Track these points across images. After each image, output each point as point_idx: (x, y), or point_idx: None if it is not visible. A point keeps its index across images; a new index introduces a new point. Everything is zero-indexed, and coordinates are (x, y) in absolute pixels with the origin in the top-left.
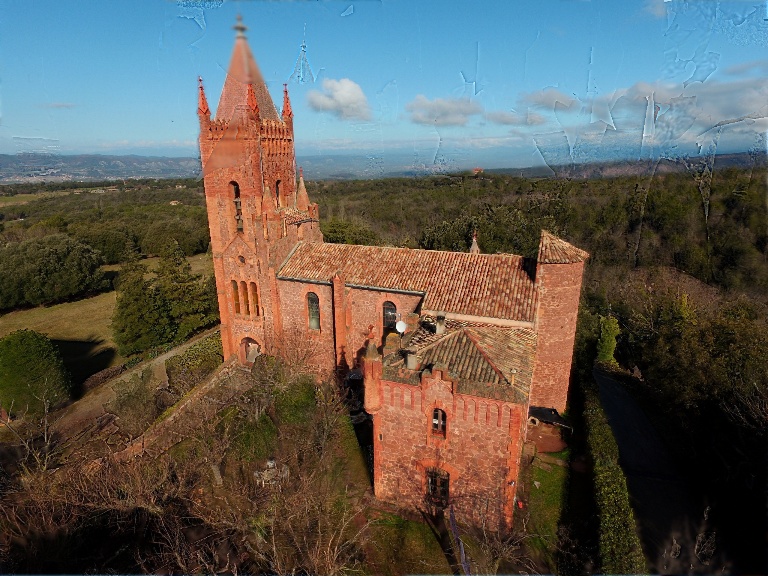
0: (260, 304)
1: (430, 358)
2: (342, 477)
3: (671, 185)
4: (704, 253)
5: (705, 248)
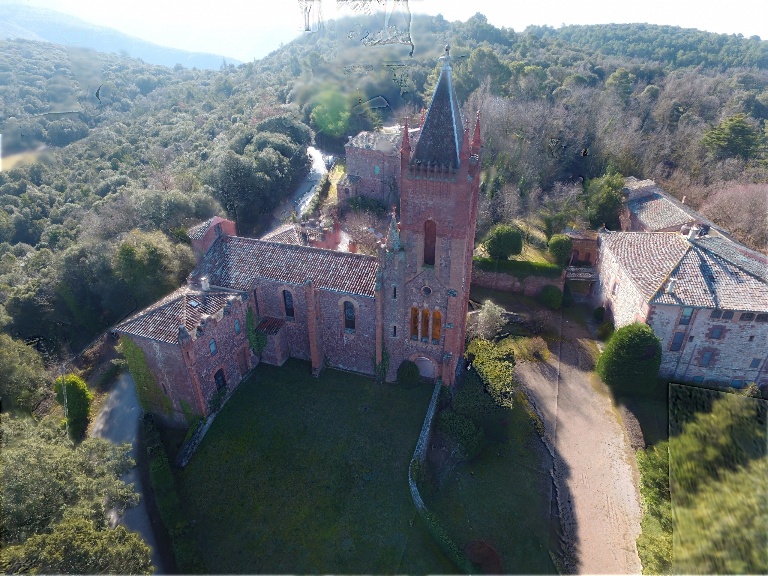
0: None
1: None
2: None
3: None
4: None
5: None
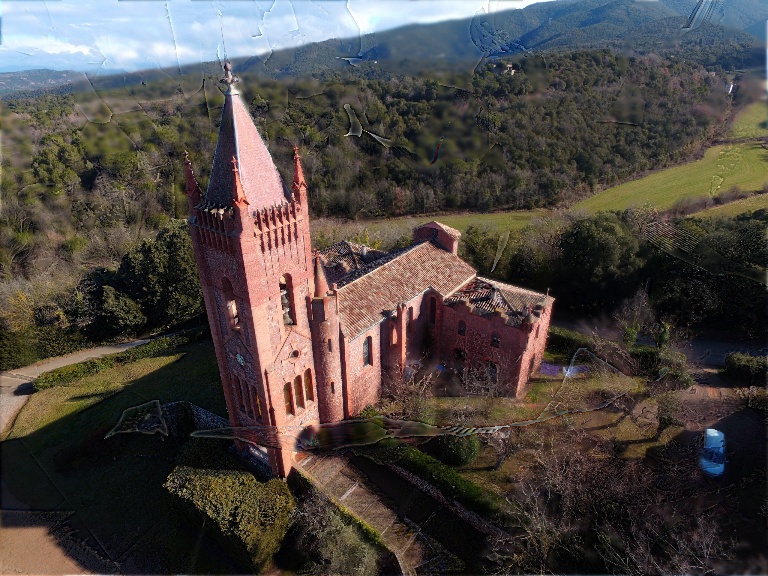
0: (314, 385)
1: (519, 308)
2: (497, 408)
3: (279, 155)
4: (309, 199)
5: (309, 196)
